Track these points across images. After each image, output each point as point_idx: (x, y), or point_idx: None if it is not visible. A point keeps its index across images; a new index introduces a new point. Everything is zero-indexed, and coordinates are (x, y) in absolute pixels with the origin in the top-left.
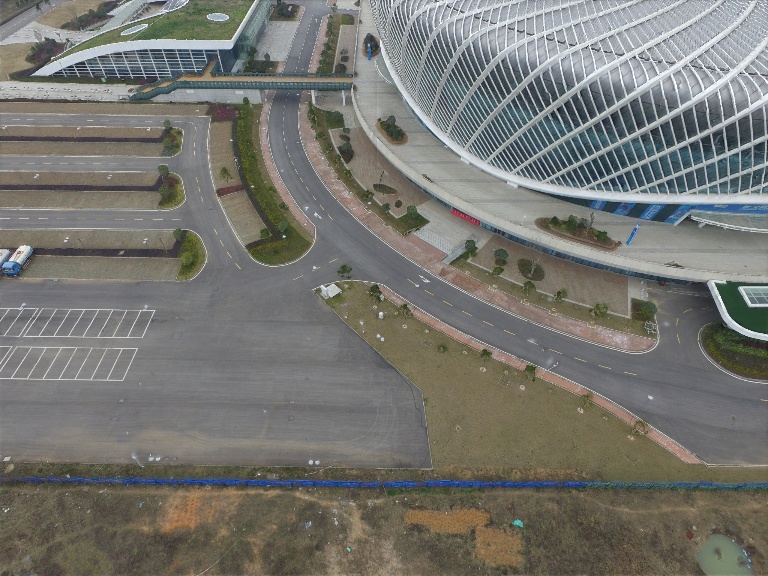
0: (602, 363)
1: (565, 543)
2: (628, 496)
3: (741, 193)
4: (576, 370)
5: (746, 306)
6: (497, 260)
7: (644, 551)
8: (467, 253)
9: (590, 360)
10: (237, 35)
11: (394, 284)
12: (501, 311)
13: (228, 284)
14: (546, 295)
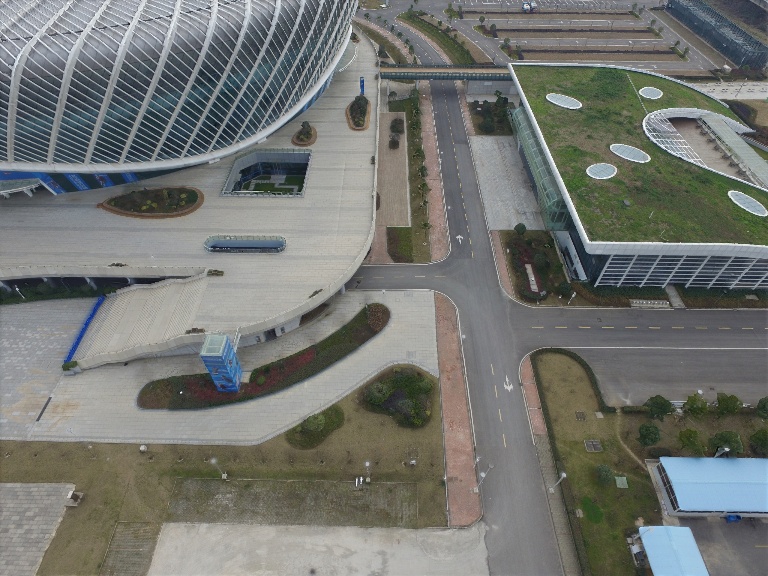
0: None
1: None
2: None
3: None
4: None
5: None
6: None
7: None
8: None
9: None
10: None
11: None
12: None
13: (429, 7)
14: None
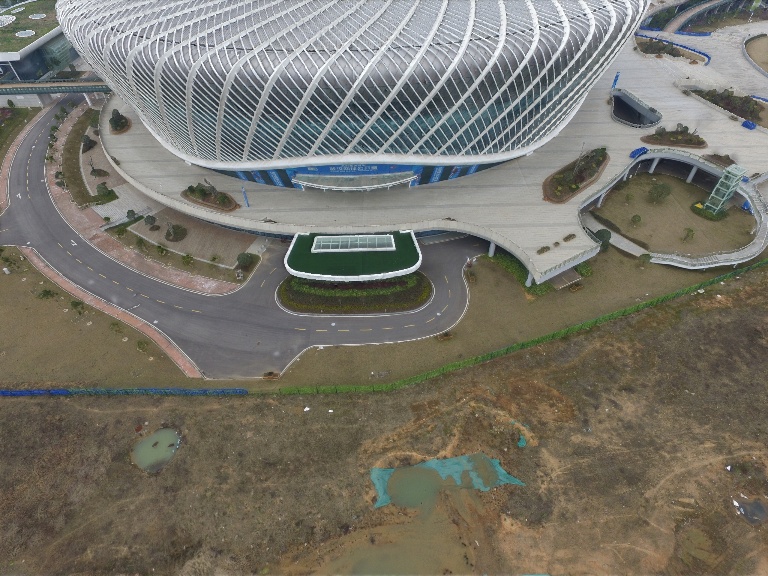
0: (178, 304)
1: (23, 435)
2: (105, 400)
3: (308, 155)
4: (151, 310)
5: (310, 252)
6: (152, 226)
7: (86, 440)
8: (130, 222)
9: (169, 302)
10: (28, 48)
11: (43, 247)
12: (122, 266)
13: None
14: (173, 253)
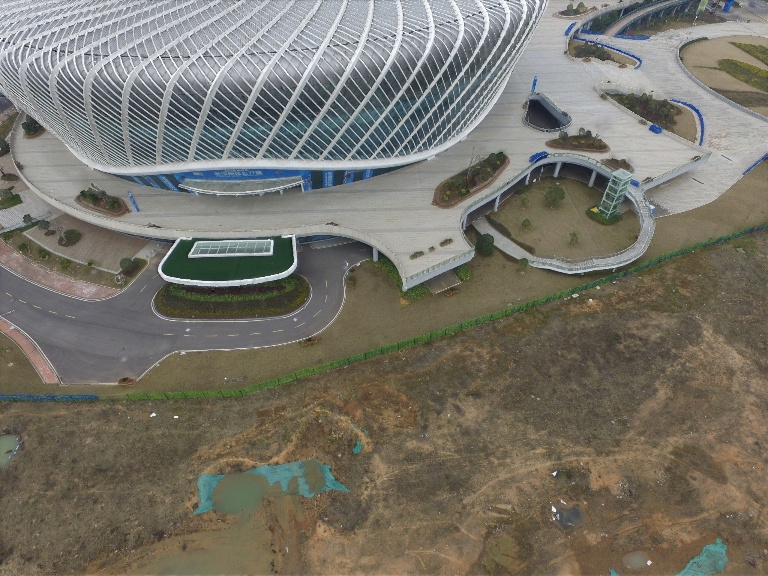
0: (53, 309)
1: None
2: None
3: (188, 160)
4: (25, 315)
5: (187, 257)
6: (48, 231)
7: None
8: (27, 226)
9: (45, 307)
10: None
11: None
12: (7, 271)
13: None
14: (62, 258)
